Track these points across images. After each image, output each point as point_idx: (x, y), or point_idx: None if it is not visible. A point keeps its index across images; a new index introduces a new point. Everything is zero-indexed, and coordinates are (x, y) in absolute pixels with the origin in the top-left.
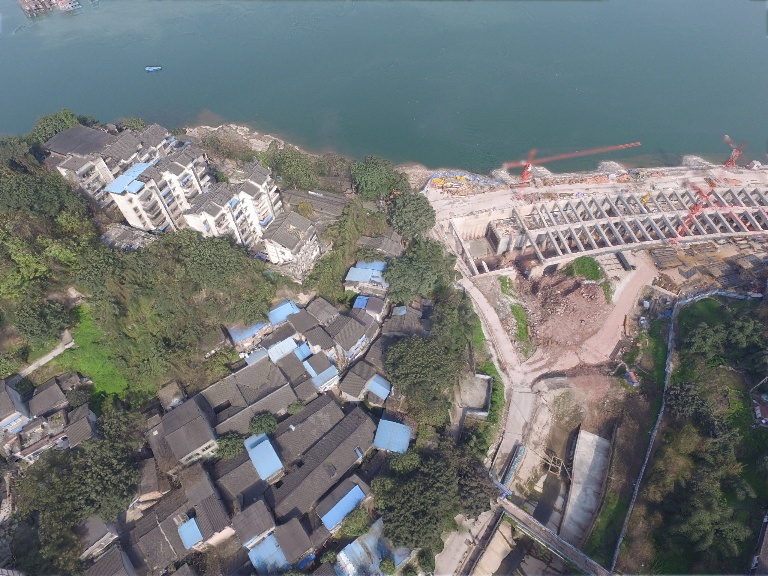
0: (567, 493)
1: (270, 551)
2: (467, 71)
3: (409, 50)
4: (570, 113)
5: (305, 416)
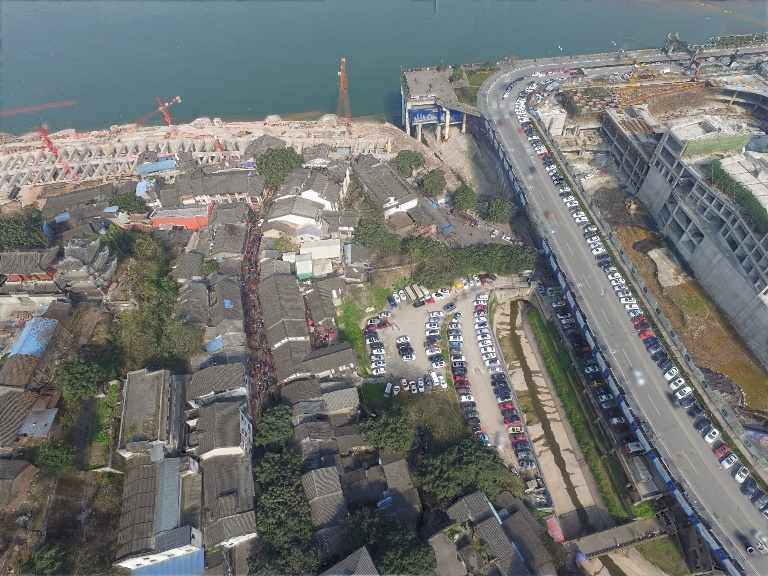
0: None
1: None
2: (98, 55)
3: (76, 39)
4: (145, 86)
5: None
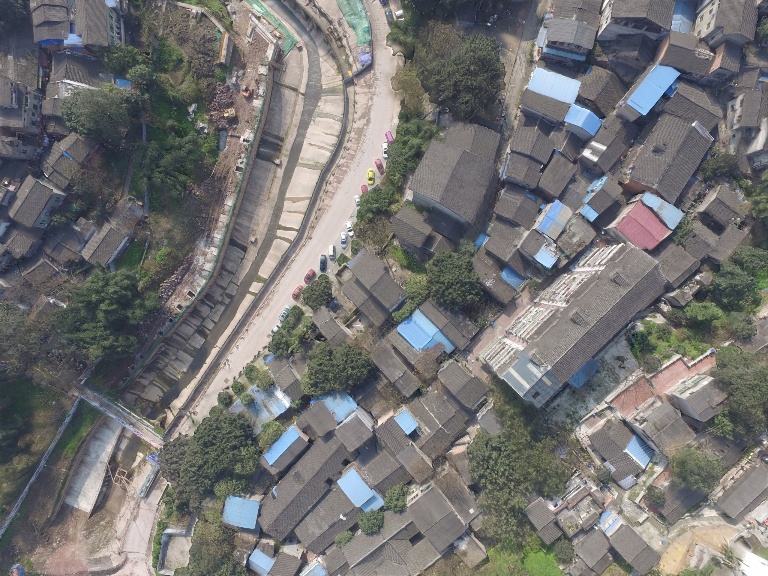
0: (115, 453)
1: (339, 409)
2: None
3: None
4: None
5: (332, 530)
